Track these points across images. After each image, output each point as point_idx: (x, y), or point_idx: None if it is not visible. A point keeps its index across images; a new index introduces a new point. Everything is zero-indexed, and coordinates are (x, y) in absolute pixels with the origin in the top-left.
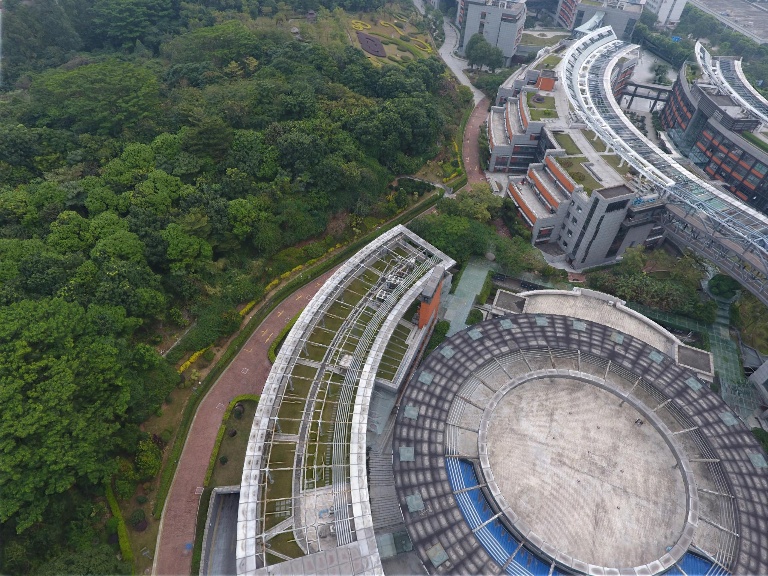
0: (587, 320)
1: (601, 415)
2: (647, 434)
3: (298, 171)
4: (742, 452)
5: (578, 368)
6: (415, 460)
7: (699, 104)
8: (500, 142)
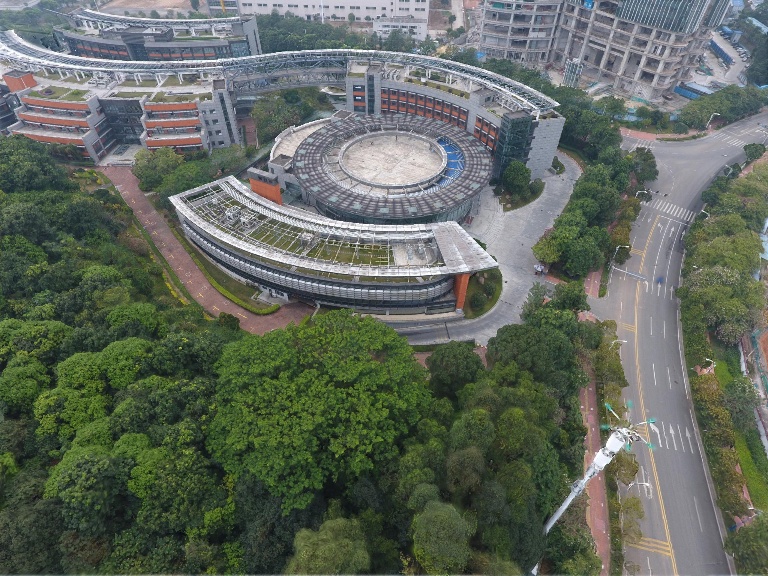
0: (307, 137)
1: (366, 153)
2: (379, 143)
3: (49, 240)
4: (395, 118)
5: (339, 148)
6: (388, 208)
7: (124, 41)
8: (76, 136)
